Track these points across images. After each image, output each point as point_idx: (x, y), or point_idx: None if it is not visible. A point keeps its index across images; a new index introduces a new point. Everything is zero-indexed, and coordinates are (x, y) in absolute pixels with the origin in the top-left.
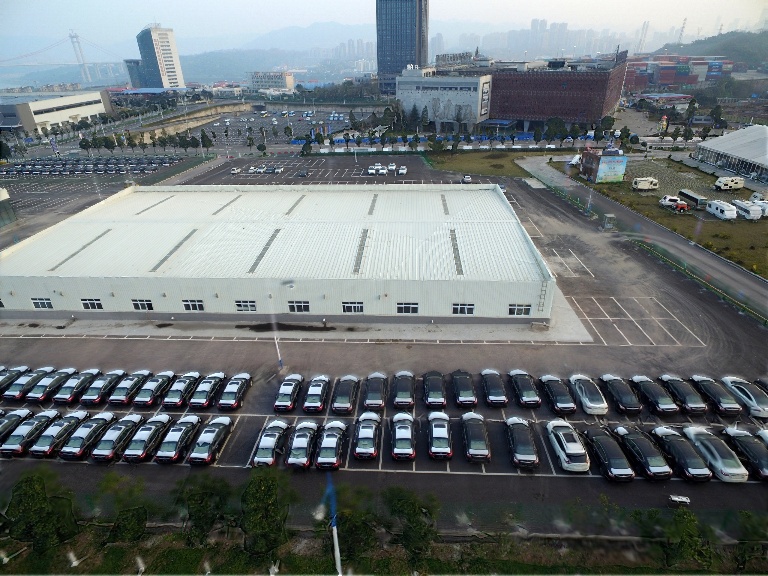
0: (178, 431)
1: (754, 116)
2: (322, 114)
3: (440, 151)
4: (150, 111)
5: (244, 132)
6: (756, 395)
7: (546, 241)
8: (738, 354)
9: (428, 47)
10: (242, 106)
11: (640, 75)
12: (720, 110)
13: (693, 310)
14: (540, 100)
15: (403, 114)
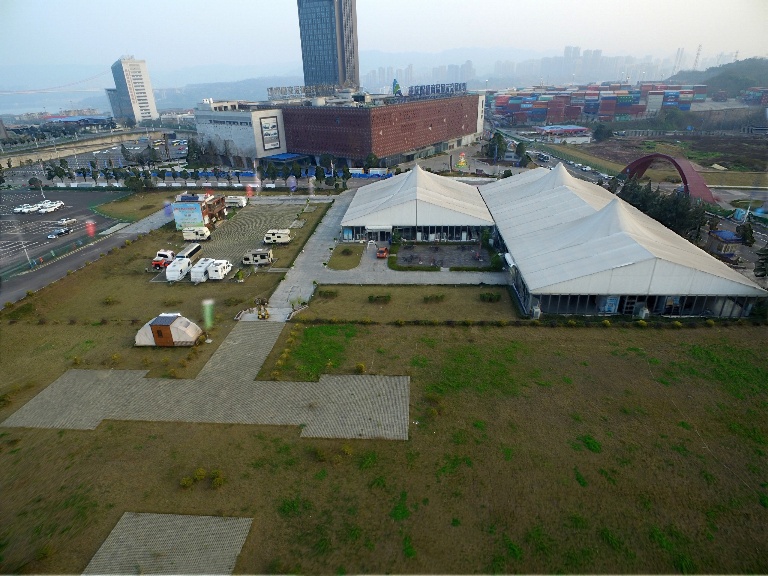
0: None
1: (602, 153)
2: None
3: (132, 189)
4: (34, 139)
5: (102, 161)
6: None
7: None
8: None
9: (359, 77)
10: (152, 134)
11: (586, 105)
12: (523, 147)
13: None
14: (322, 135)
15: (195, 147)
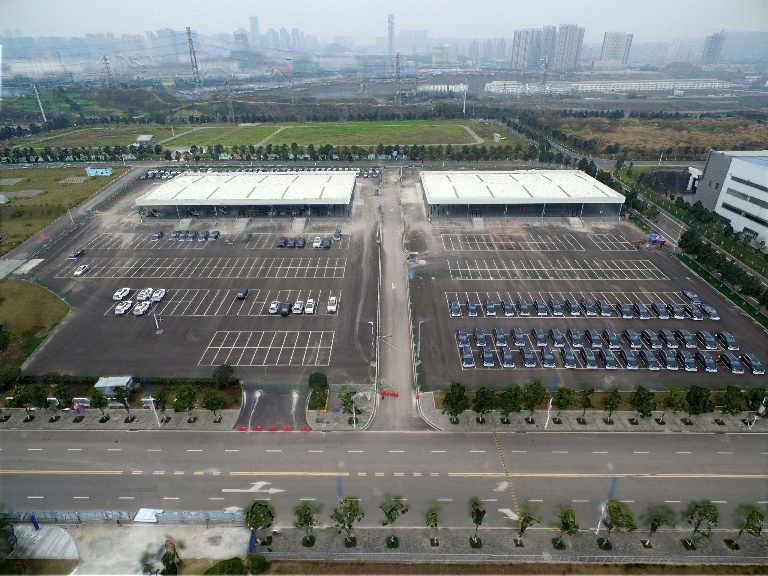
0: (277, 169)
1: None
2: None
3: None
4: None
5: None
6: None
7: (135, 211)
8: None
9: None
10: None
11: None
12: None
13: (138, 189)
14: None
15: None
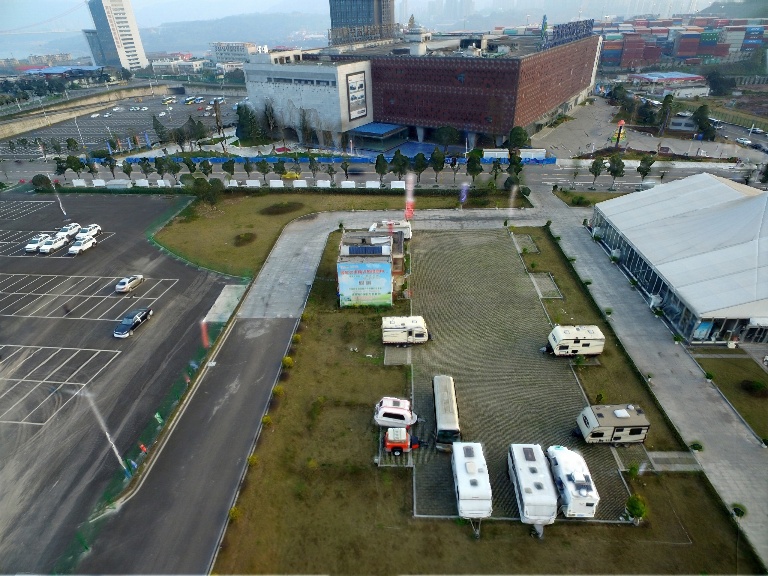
0: None
1: None
2: (237, 100)
3: (200, 197)
4: (15, 100)
5: None
6: None
7: None
8: None
9: (395, 13)
10: (156, 89)
11: (657, 44)
12: (706, 112)
13: None
14: (432, 99)
15: None
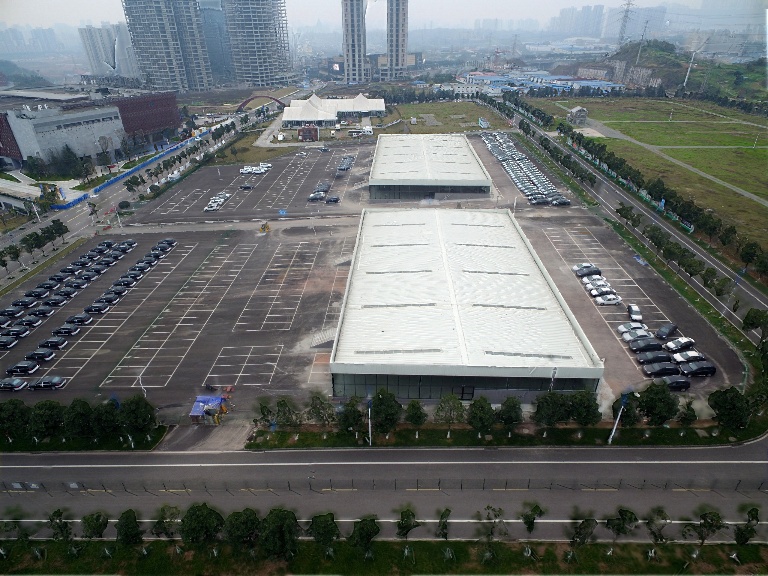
0: None
1: None
2: None
3: None
4: None
5: None
6: (489, 136)
7: None
8: (471, 138)
9: None
10: None
11: None
12: (186, 109)
13: None
14: (140, 119)
15: (71, 155)
